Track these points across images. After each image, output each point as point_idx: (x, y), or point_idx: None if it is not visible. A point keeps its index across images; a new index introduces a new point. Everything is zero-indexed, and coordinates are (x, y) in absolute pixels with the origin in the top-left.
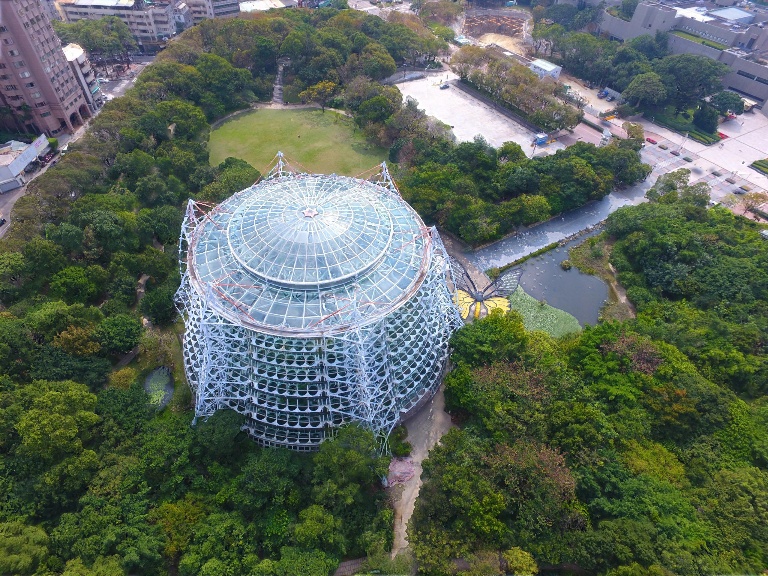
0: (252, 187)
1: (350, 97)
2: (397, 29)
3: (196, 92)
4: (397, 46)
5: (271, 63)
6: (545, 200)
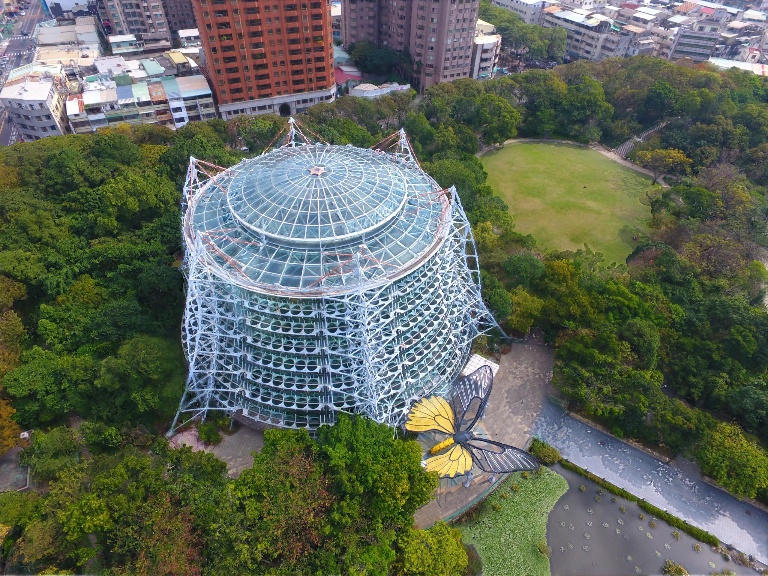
0: (368, 149)
1: (698, 184)
2: None
3: (540, 104)
4: None
5: (655, 114)
6: None
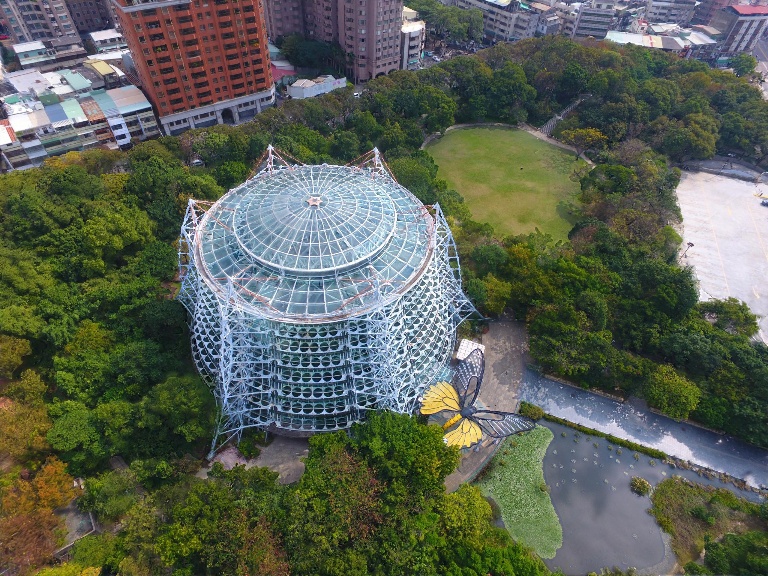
0: (343, 167)
1: (614, 157)
2: (763, 112)
3: (472, 91)
4: (741, 130)
5: (571, 93)
6: (696, 394)
